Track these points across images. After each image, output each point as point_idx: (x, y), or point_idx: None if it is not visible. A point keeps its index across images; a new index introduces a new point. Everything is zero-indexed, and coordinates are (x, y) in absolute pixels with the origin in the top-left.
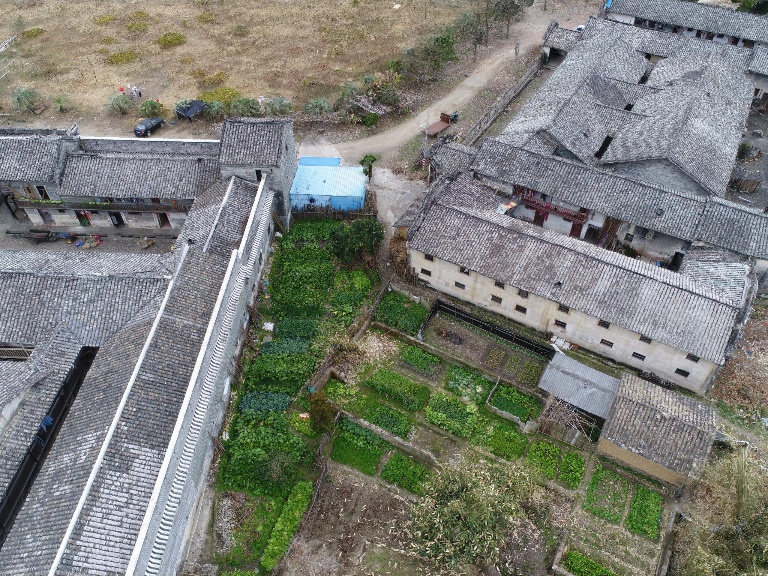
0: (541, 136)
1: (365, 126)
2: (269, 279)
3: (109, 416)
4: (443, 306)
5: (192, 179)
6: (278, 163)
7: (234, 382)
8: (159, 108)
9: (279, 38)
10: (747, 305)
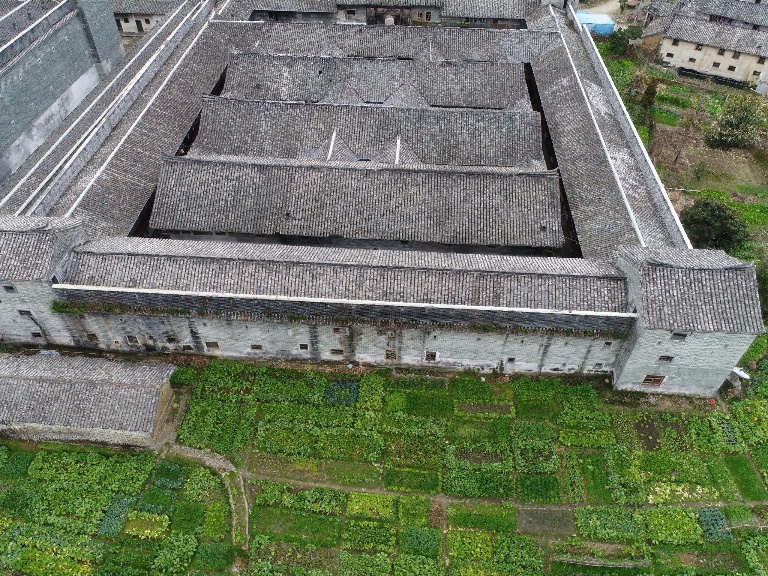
0: None
1: (584, 3)
2: None
3: (569, 72)
4: (683, 71)
5: (521, 8)
6: None
7: None
8: None
9: None
10: None
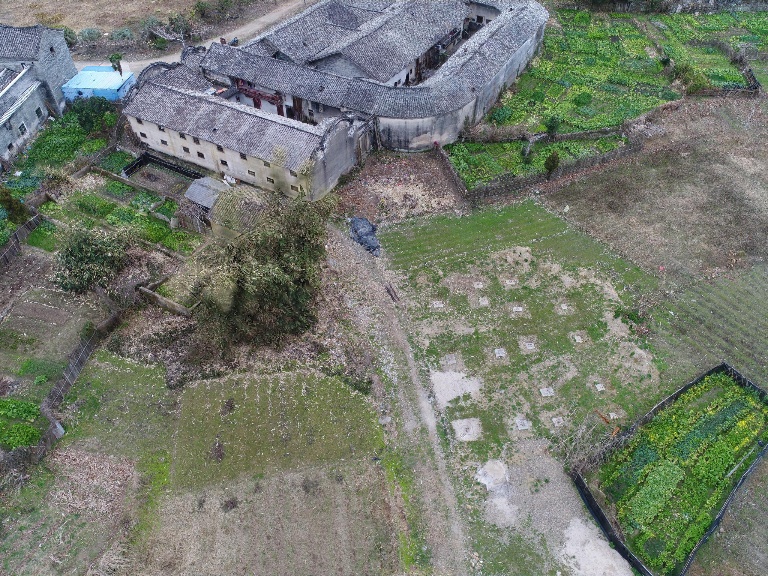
0: (265, 43)
1: (160, 50)
2: (32, 146)
3: None
4: (151, 157)
5: None
6: (34, 56)
7: None
8: None
9: None
10: (325, 133)
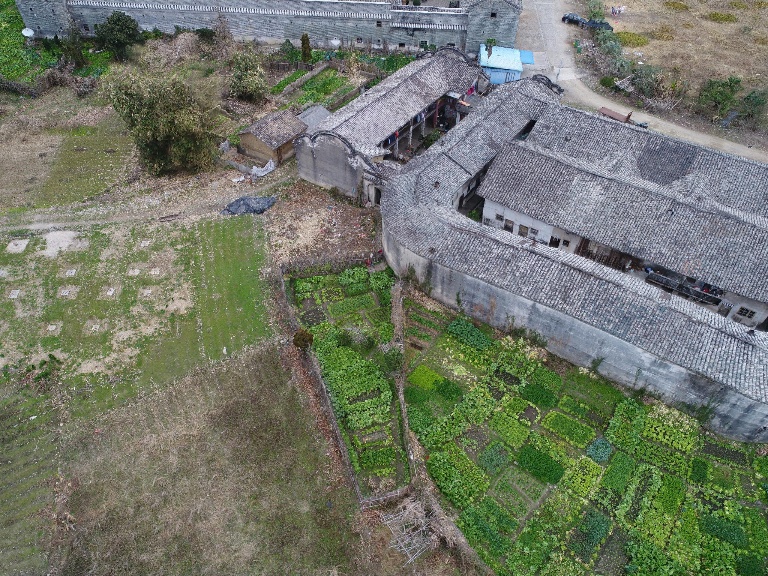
0: None
1: None
2: None
3: None
4: None
5: None
6: (467, 7)
7: (341, 47)
8: (597, 18)
9: (763, 56)
10: None
